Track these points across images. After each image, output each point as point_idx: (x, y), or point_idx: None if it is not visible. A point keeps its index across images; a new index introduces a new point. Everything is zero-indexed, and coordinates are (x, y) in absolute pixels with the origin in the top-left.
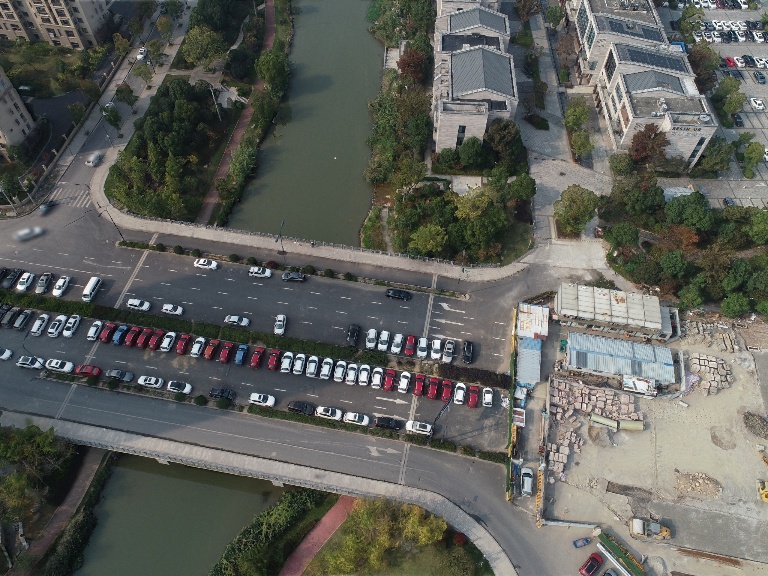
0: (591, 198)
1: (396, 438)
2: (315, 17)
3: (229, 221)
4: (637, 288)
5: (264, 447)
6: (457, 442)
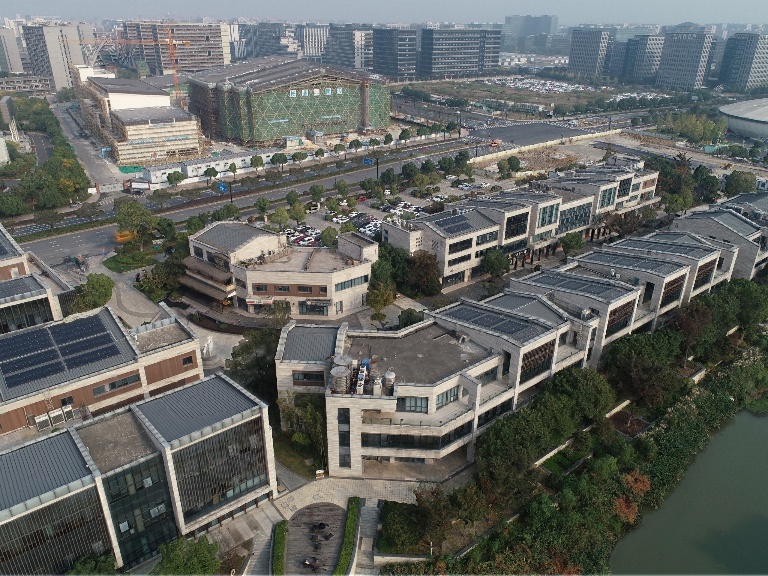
0: None
1: None
2: None
3: None
4: None
5: None
6: None
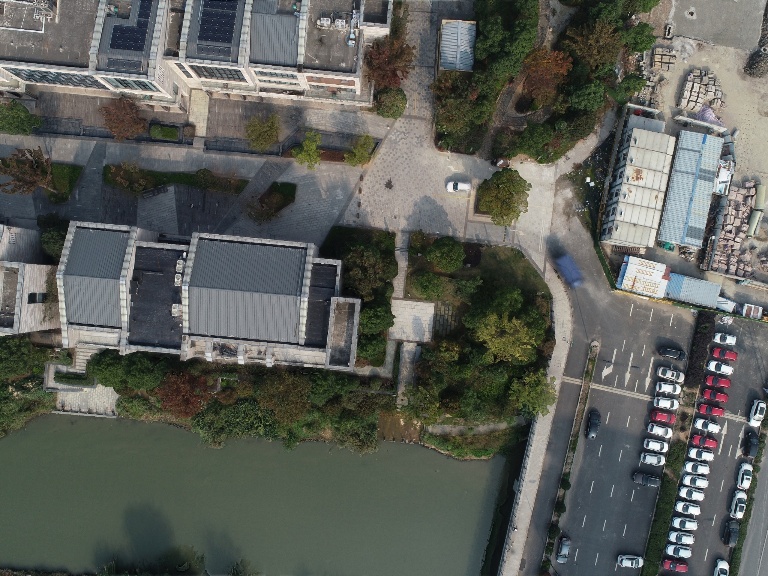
0: (516, 181)
1: (766, 437)
2: None
3: None
4: (586, 138)
5: (766, 566)
6: (767, 375)
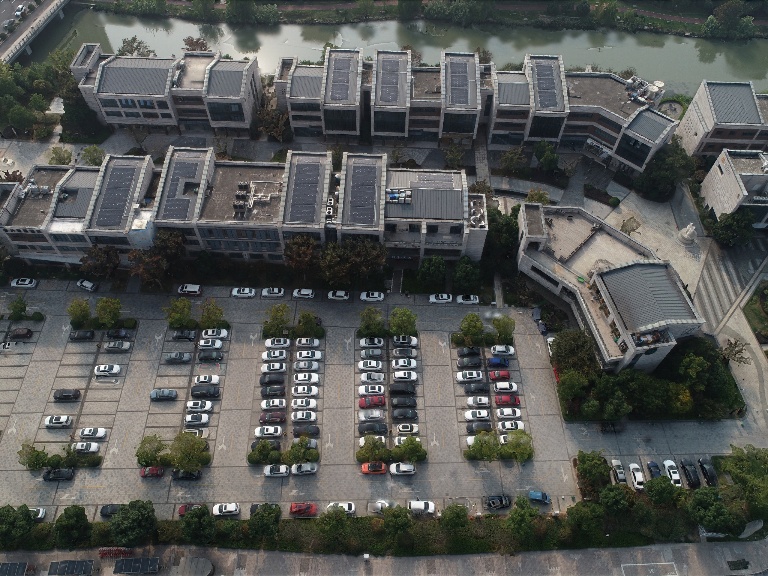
0: None
1: None
2: (364, 37)
3: (99, 11)
4: None
5: None
6: None
